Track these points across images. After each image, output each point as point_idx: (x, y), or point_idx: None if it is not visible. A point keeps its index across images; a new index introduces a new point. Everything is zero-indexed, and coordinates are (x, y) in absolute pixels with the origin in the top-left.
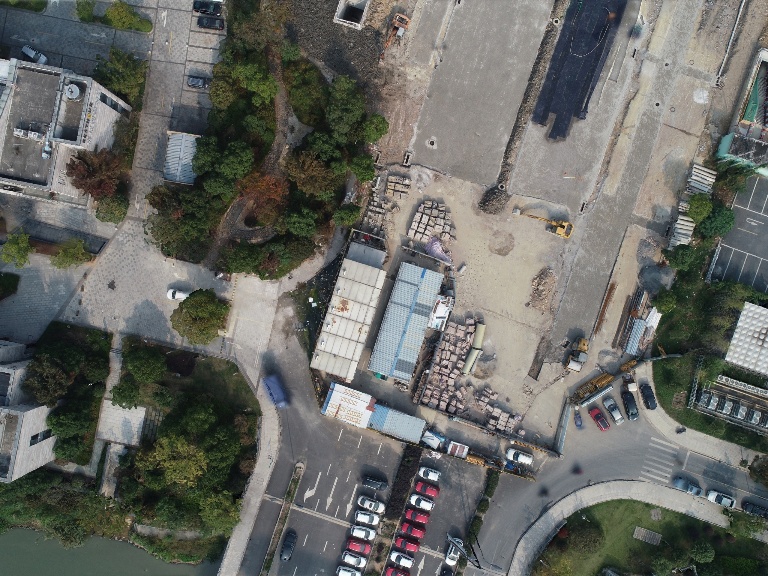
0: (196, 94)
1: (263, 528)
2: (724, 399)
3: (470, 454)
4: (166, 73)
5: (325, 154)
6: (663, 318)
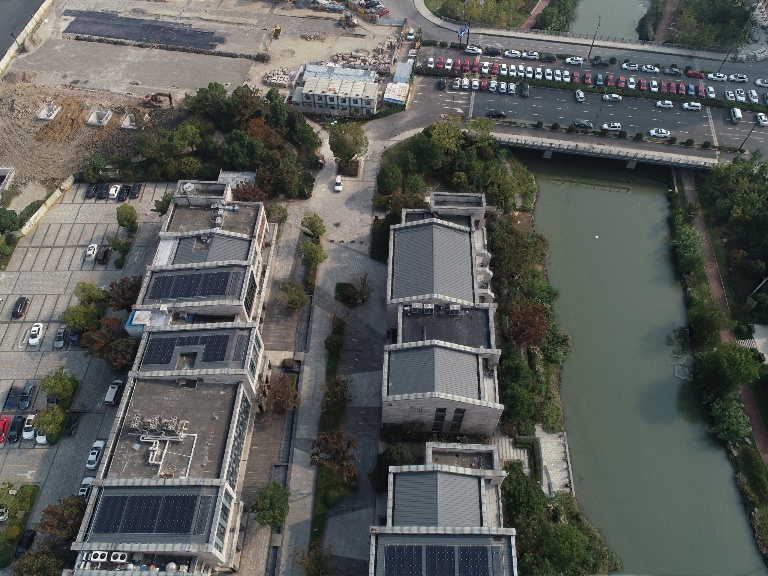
0: None
1: None
2: None
3: None
4: None
5: (234, 102)
6: None
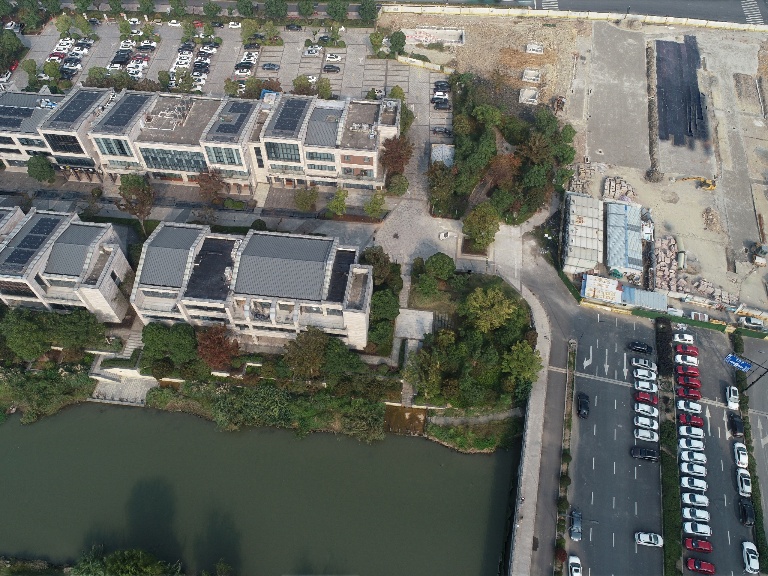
0: (439, 138)
1: (555, 394)
2: None
3: None
4: (418, 130)
5: None
6: None
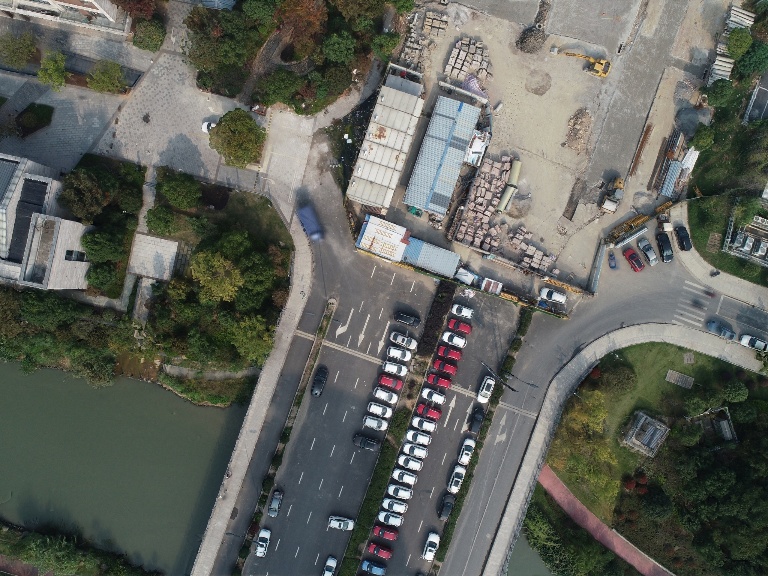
0: None
1: (294, 364)
2: (759, 242)
3: (504, 291)
4: None
5: None
6: (699, 160)
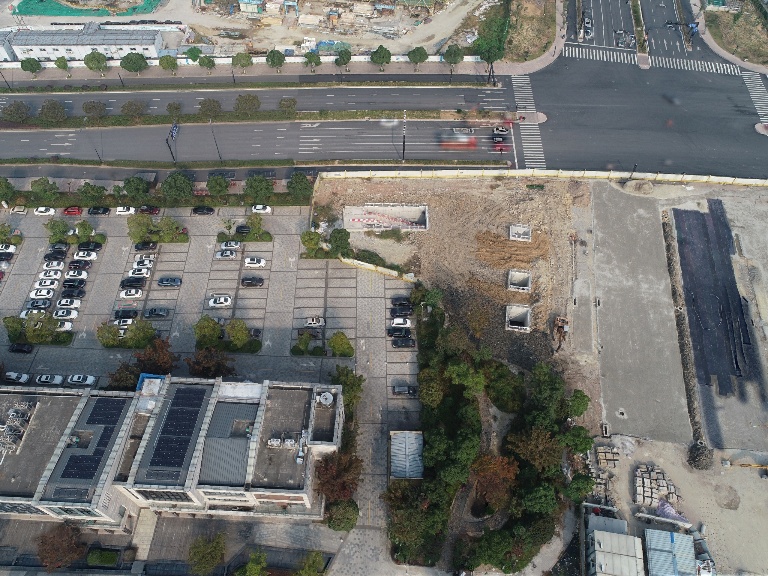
0: (400, 401)
1: None
2: None
3: None
4: (371, 387)
5: (545, 429)
6: None
